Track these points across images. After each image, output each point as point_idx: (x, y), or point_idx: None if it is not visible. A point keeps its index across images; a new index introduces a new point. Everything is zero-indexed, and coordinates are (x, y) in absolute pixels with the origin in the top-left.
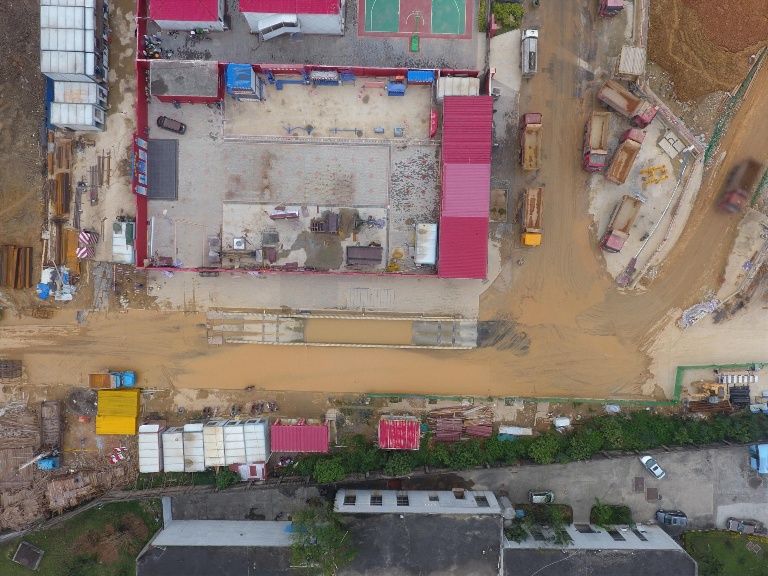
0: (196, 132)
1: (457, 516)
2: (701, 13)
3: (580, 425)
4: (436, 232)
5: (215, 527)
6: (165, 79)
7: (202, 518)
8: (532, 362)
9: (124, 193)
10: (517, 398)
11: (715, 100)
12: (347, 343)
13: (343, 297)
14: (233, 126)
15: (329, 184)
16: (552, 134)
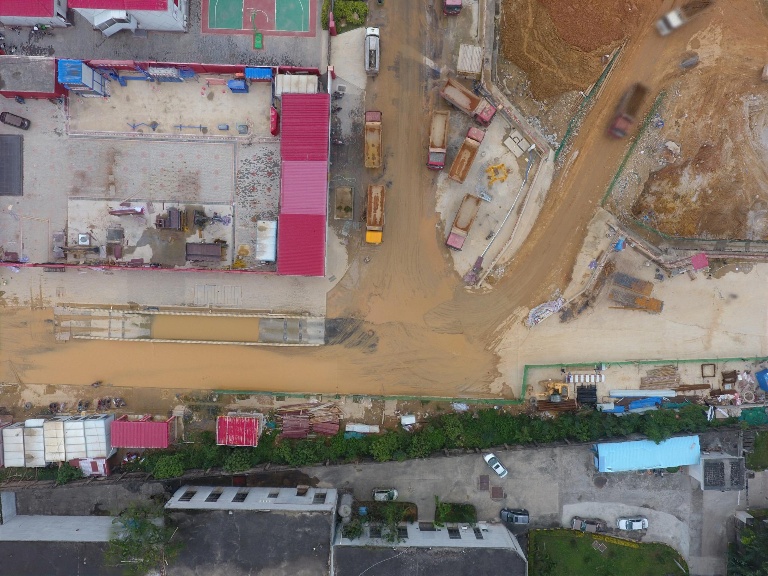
0: (41, 128)
1: (287, 513)
2: (553, 12)
3: (427, 423)
4: (276, 229)
5: (55, 522)
6: (2, 74)
7: (47, 513)
8: (380, 360)
9: None
10: (365, 396)
11: (569, 99)
12: (194, 340)
13: (190, 294)
14: (78, 122)
15: (174, 181)
16: (398, 132)
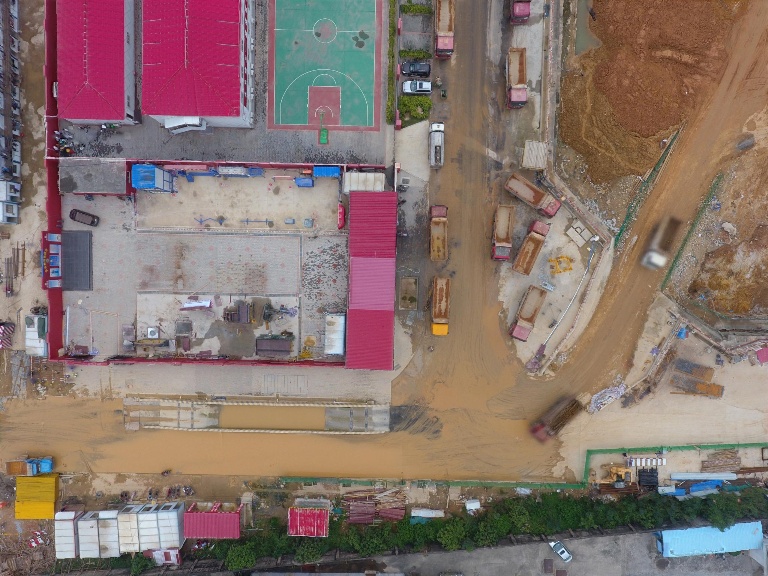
0: (109, 223)
1: None
2: (612, 99)
3: (491, 508)
4: (344, 324)
5: None
6: (74, 176)
7: None
8: (444, 446)
9: (39, 284)
10: (429, 481)
11: (627, 184)
12: (261, 428)
13: (257, 383)
14: (146, 217)
15: (241, 274)
16: (461, 223)
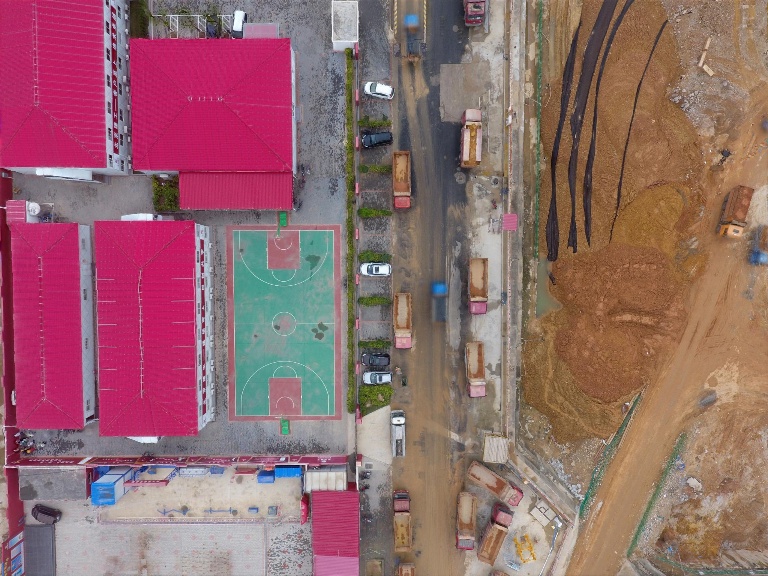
0: (72, 517)
1: None
2: (573, 368)
3: None
4: None
5: None
6: (34, 485)
7: None
8: None
9: None
10: None
11: (591, 448)
12: None
13: None
14: (109, 510)
15: (206, 562)
16: (426, 504)
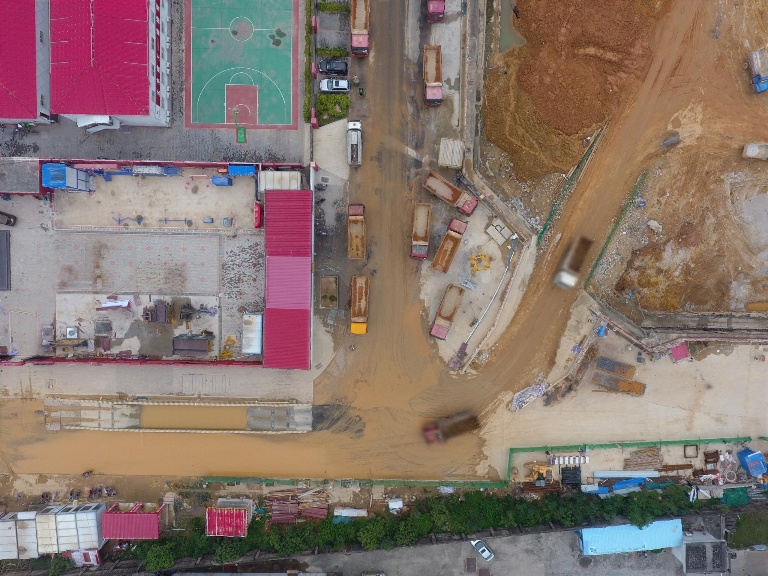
0: (27, 223)
1: None
2: (534, 97)
3: (414, 507)
4: (261, 323)
5: None
6: None
7: None
8: (367, 445)
9: None
10: (353, 480)
11: (551, 182)
12: (183, 428)
13: (178, 383)
14: (64, 217)
15: (161, 273)
16: (382, 221)
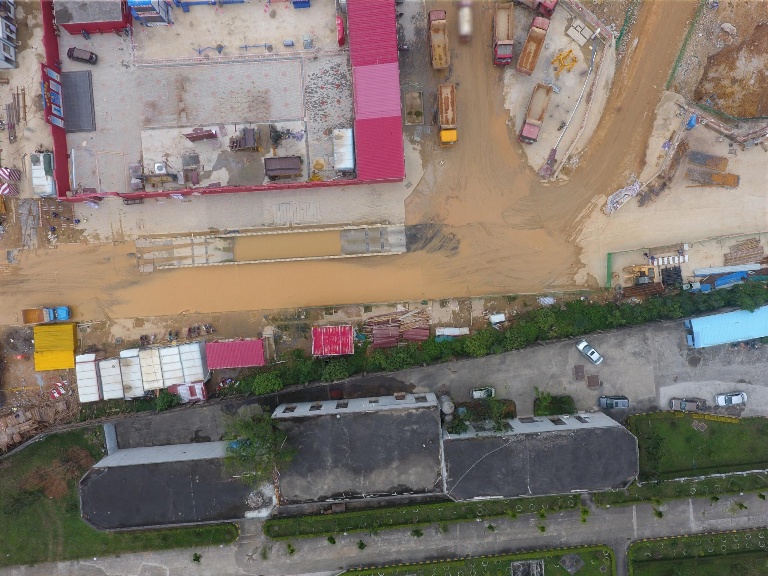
0: (108, 61)
1: (394, 412)
2: None
3: (516, 320)
4: (352, 136)
5: (159, 450)
6: (69, 7)
7: (148, 445)
8: (463, 262)
9: (42, 128)
10: (451, 299)
11: None
12: (277, 259)
13: (269, 214)
14: (144, 52)
15: (244, 102)
16: (461, 33)
